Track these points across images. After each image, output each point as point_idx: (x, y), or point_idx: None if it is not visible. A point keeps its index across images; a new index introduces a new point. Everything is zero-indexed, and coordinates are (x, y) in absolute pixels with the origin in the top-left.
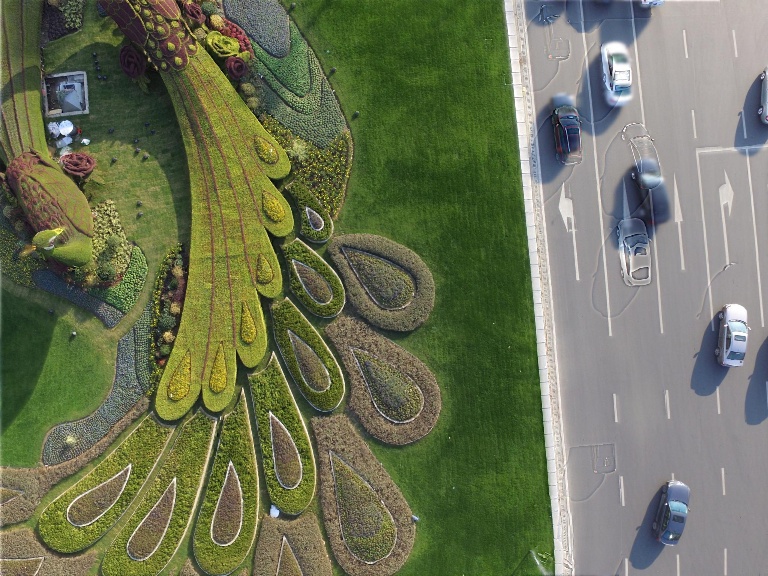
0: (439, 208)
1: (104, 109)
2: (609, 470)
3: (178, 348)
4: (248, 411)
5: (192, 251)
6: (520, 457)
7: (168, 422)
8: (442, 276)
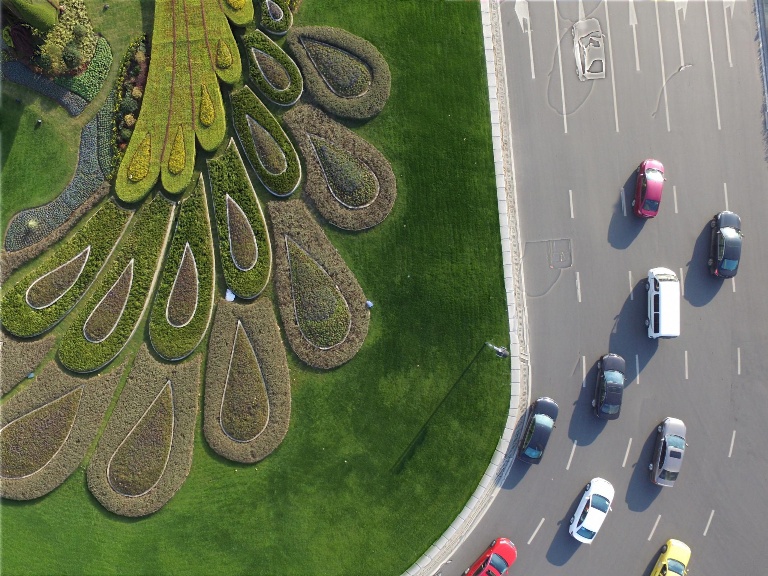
0: (396, 4)
1: None
2: (565, 265)
3: (139, 130)
4: (206, 195)
5: (154, 36)
6: (475, 248)
7: (128, 207)
8: (399, 68)
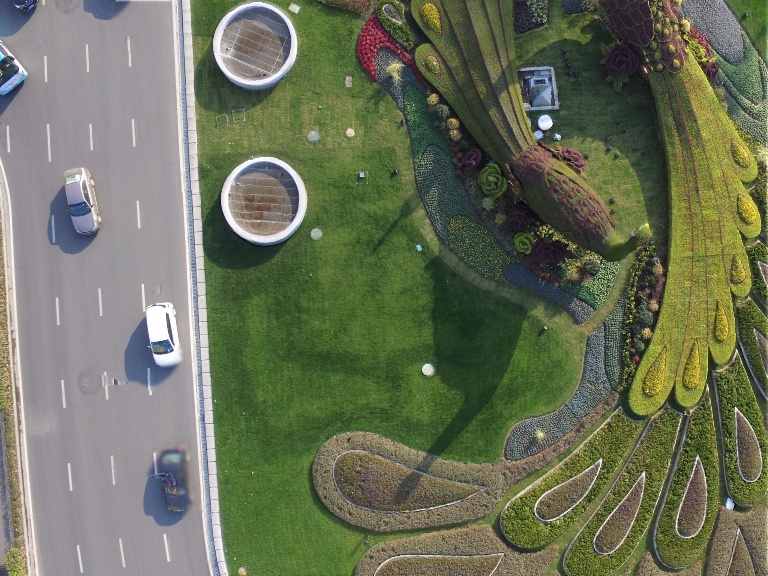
0: None
1: (575, 106)
2: None
3: (655, 344)
4: (711, 406)
5: (673, 249)
6: None
7: (634, 417)
8: None
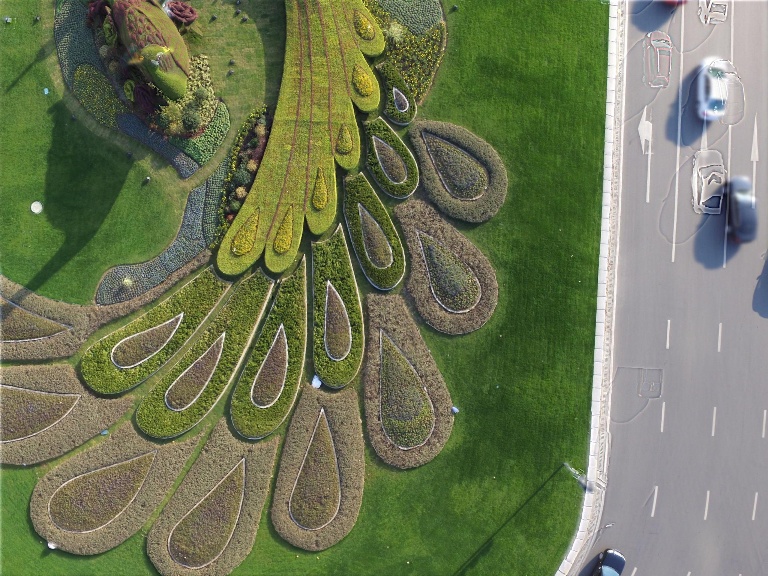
0: (522, 110)
1: None
2: (654, 395)
3: (248, 204)
4: (306, 278)
5: (277, 112)
6: (567, 367)
7: (226, 278)
8: (516, 176)
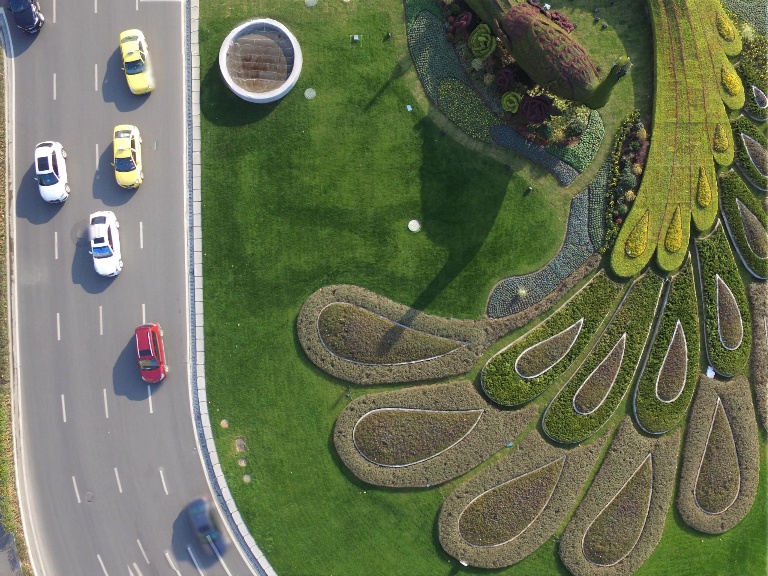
0: None
1: None
2: None
3: (638, 207)
4: (693, 274)
5: (657, 115)
6: None
7: (617, 280)
8: None
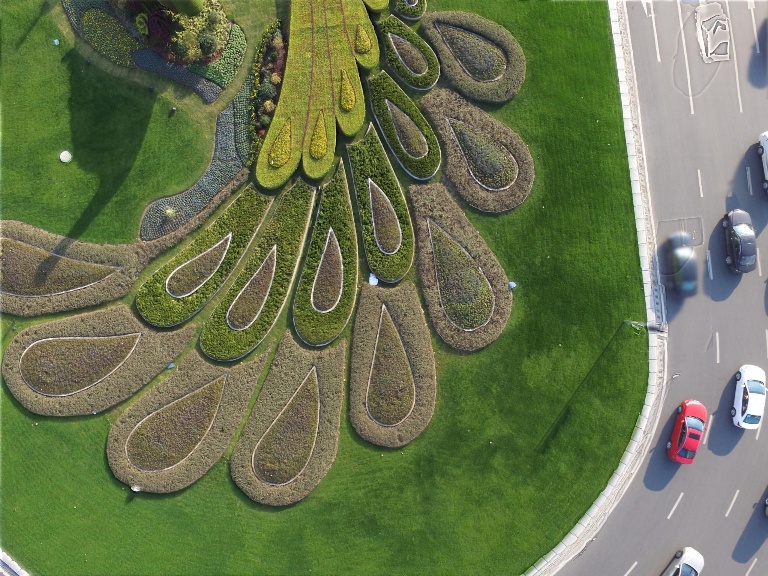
0: None
1: None
2: (697, 243)
3: (279, 116)
4: (347, 180)
5: (292, 22)
6: (611, 228)
7: (267, 193)
8: (531, 52)
